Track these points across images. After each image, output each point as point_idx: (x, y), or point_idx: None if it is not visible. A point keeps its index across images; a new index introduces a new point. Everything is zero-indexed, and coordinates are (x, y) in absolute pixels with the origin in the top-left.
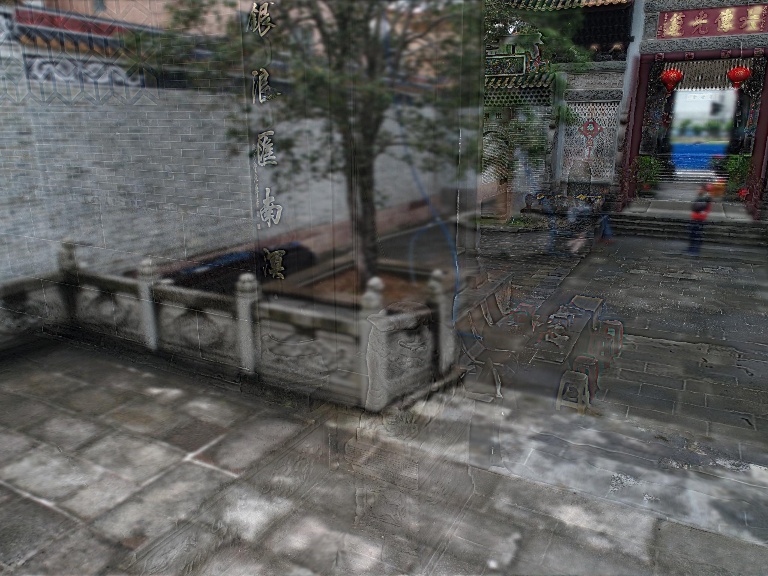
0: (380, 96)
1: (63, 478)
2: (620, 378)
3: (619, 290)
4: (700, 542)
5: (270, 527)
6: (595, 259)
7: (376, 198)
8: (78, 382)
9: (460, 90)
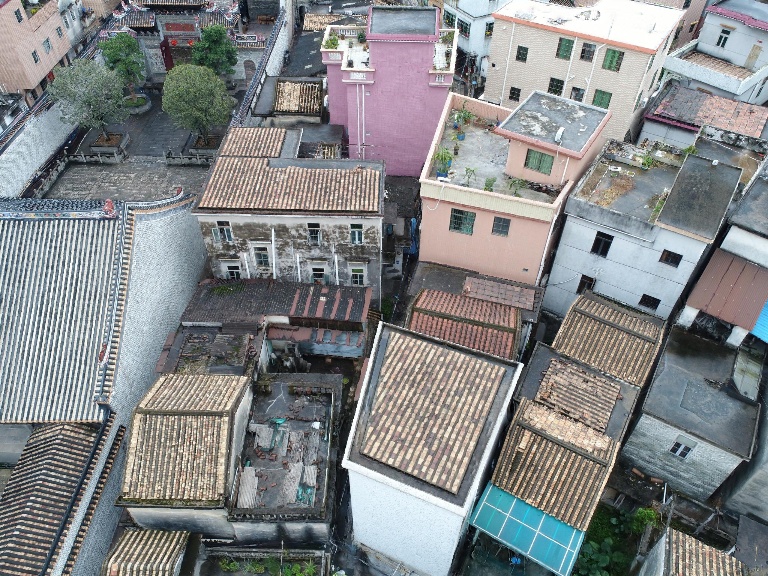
0: None
1: None
2: None
3: None
4: None
5: None
6: None
7: None
8: None
9: None
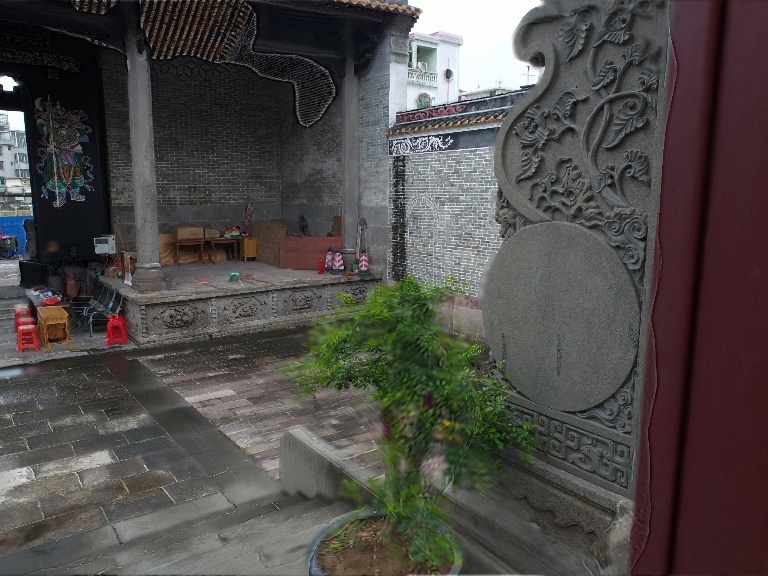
0: None
1: None
2: (6, 339)
3: (85, 411)
4: None
5: None
6: (224, 463)
7: None
8: None
9: (30, 163)
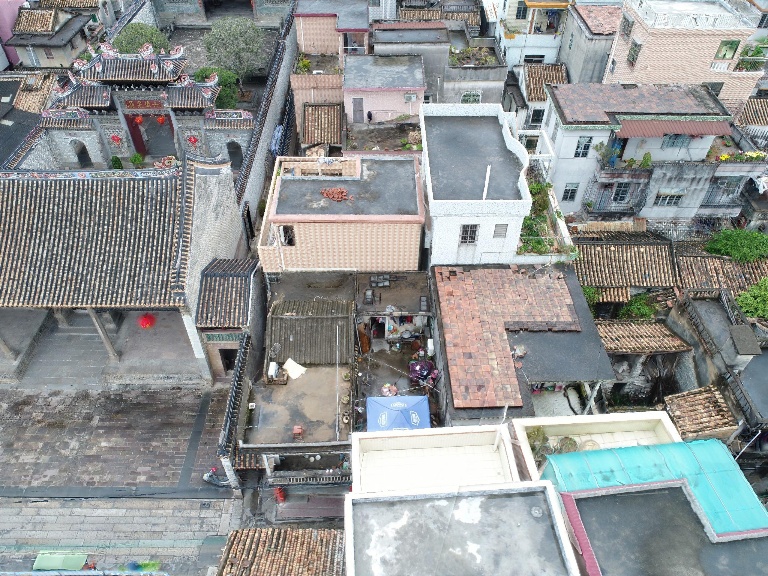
0: None
1: (19, 330)
2: None
3: None
4: None
5: (48, 326)
6: None
7: None
8: (5, 316)
9: None
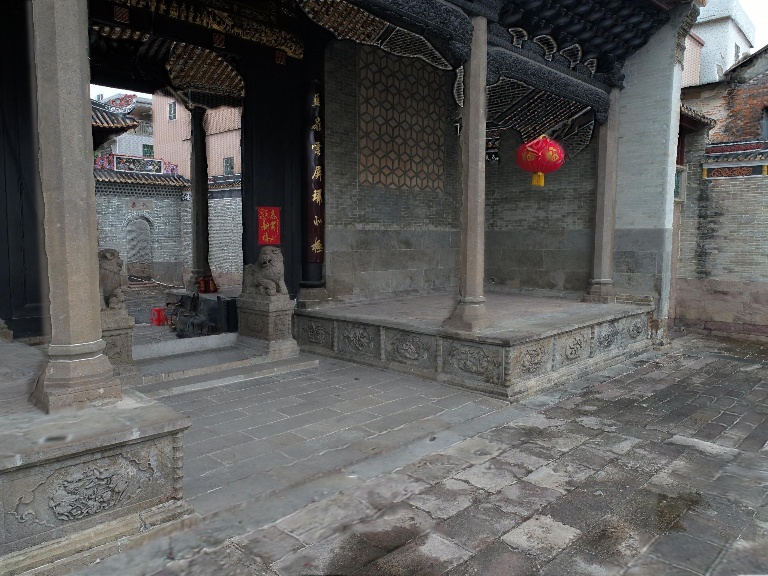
0: (36, 155)
1: None
2: None
3: None
4: (205, 341)
5: None
6: None
7: (37, 210)
8: None
9: None
